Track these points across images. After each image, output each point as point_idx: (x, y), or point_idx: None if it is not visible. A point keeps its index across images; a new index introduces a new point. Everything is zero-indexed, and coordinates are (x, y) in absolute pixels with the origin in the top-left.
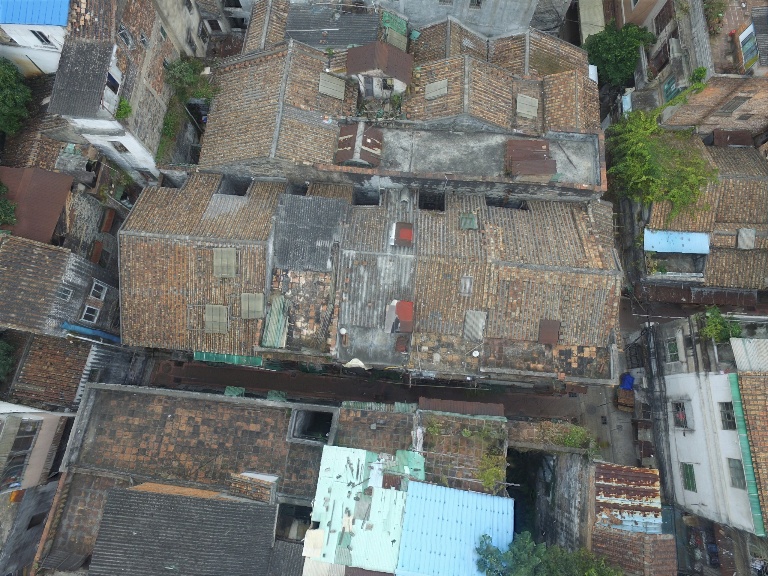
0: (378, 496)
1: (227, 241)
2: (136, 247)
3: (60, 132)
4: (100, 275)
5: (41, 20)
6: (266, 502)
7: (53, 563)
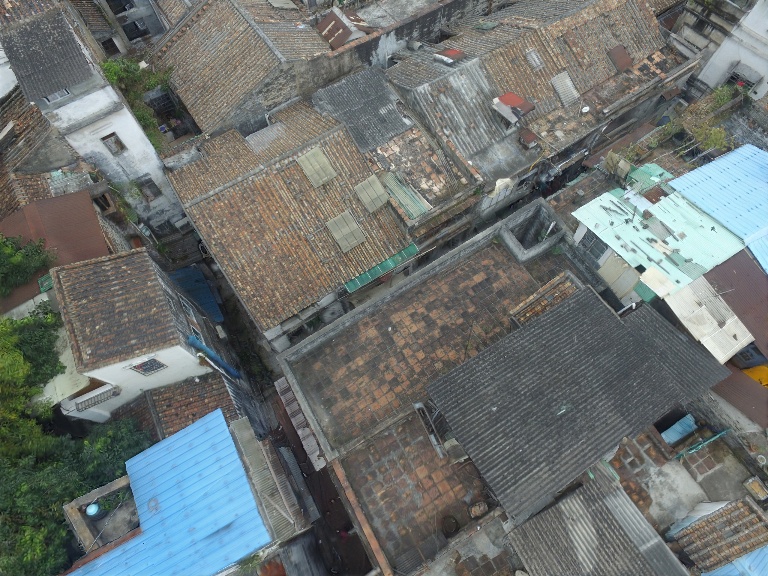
0: (659, 212)
1: (304, 145)
2: (212, 213)
3: (40, 152)
4: (179, 291)
5: None
6: (576, 292)
7: (413, 563)
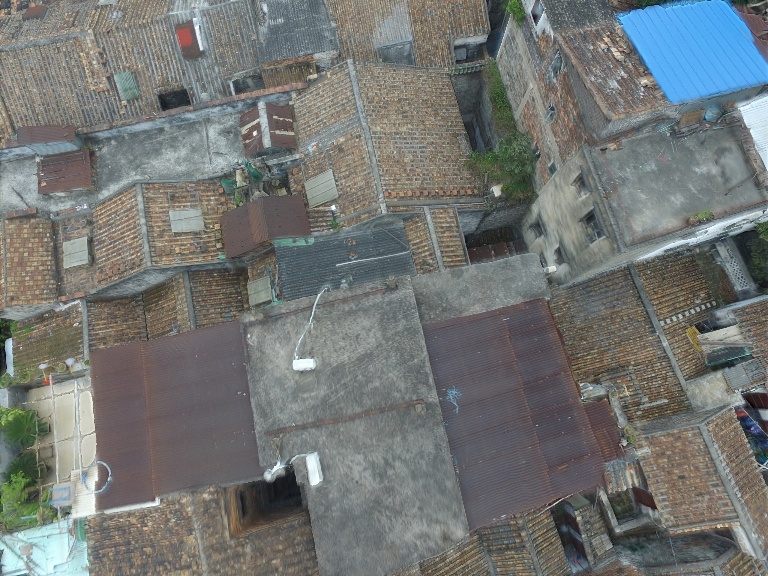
0: None
1: None
2: None
3: None
4: None
5: (652, 13)
6: None
7: None
